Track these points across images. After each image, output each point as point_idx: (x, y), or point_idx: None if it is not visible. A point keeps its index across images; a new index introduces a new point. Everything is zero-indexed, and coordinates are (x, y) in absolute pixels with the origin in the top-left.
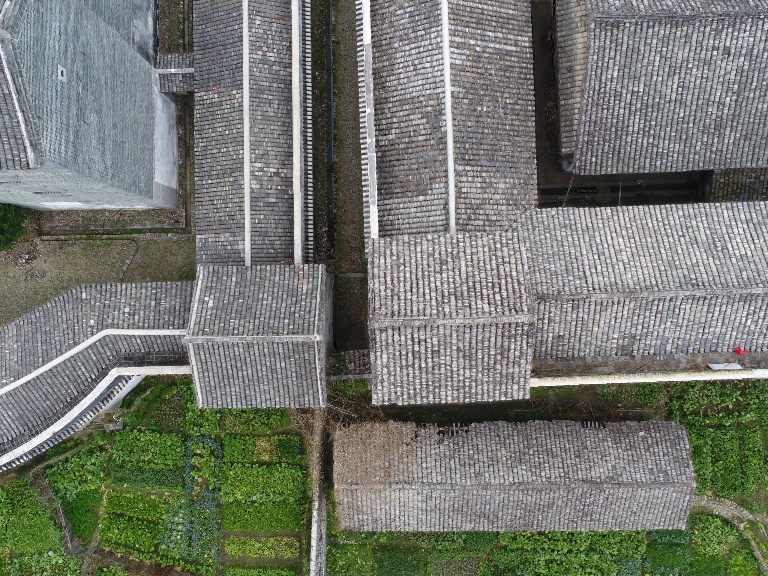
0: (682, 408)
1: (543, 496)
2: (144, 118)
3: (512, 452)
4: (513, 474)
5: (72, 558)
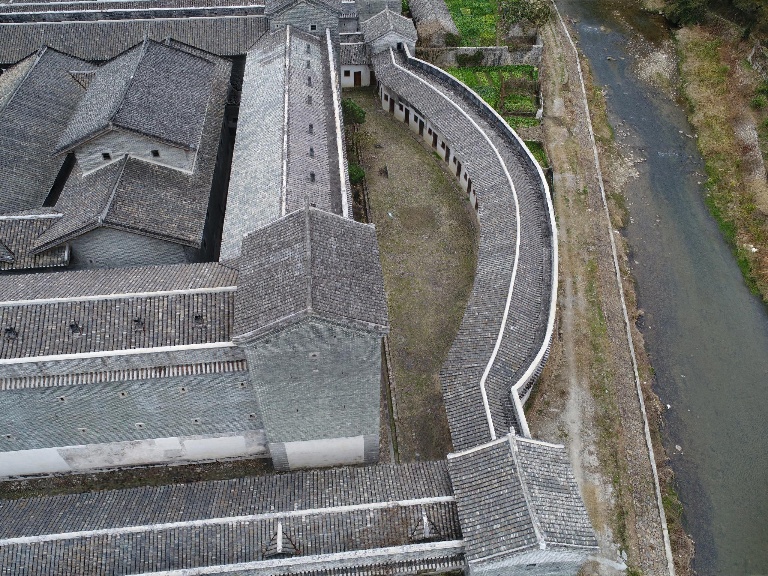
0: (402, 7)
1: (434, 2)
2: None
3: (421, 8)
4: (428, 5)
5: (507, 118)
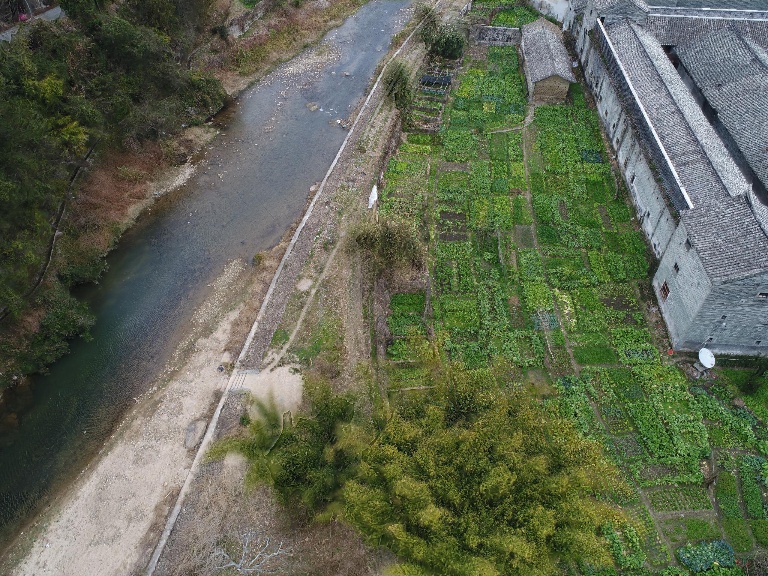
0: None
1: None
2: (657, 2)
3: None
4: None
5: None
